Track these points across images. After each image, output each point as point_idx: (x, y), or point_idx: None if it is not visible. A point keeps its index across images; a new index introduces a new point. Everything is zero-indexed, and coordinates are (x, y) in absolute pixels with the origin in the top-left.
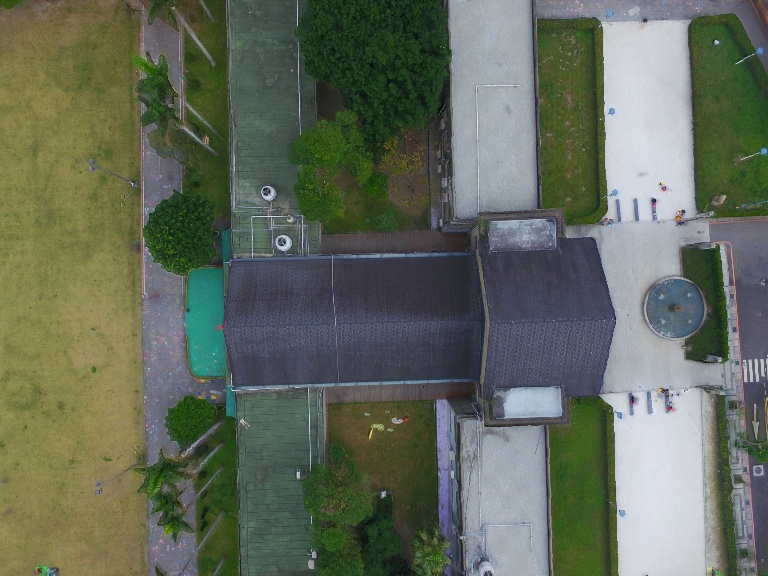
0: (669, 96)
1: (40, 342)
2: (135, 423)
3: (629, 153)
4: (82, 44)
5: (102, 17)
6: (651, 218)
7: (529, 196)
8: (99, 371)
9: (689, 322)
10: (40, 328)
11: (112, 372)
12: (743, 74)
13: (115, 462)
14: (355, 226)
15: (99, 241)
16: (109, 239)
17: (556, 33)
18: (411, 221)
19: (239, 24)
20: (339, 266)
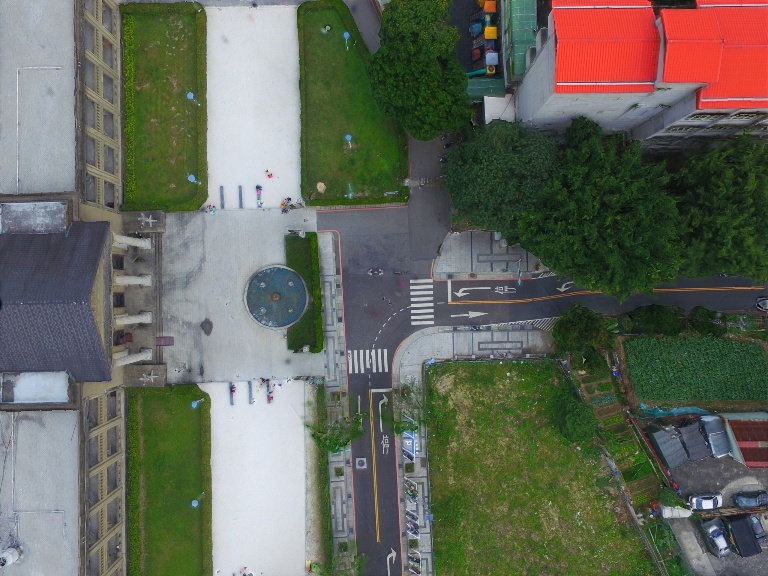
0: (279, 82)
1: None
2: None
3: (236, 140)
4: None
5: None
6: (255, 205)
7: (70, 180)
8: None
9: (290, 311)
10: None
11: None
12: (355, 60)
13: None
14: None
15: None
16: None
17: (163, 18)
18: None
19: None
20: None
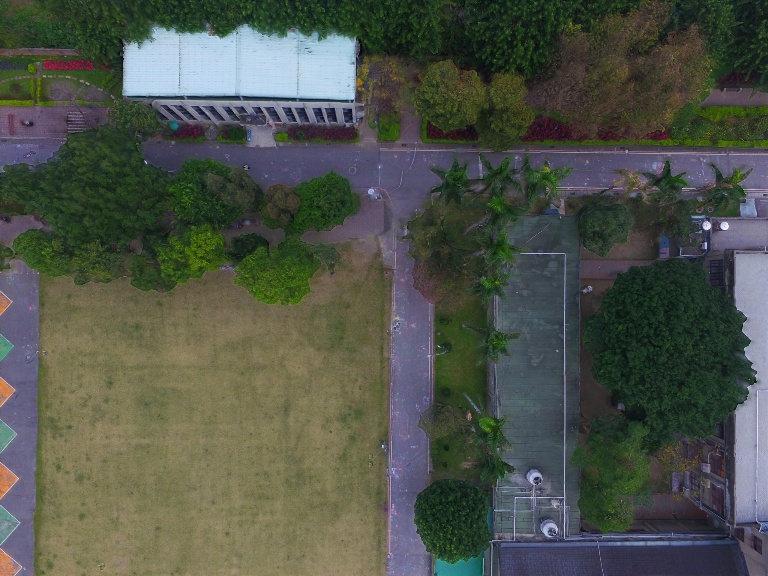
0: None
1: None
2: None
3: None
4: (335, 303)
5: (355, 276)
6: None
7: None
8: None
9: None
10: None
11: None
12: None
13: None
14: None
15: (347, 501)
16: (357, 499)
17: None
18: (652, 484)
19: (506, 303)
20: (606, 555)
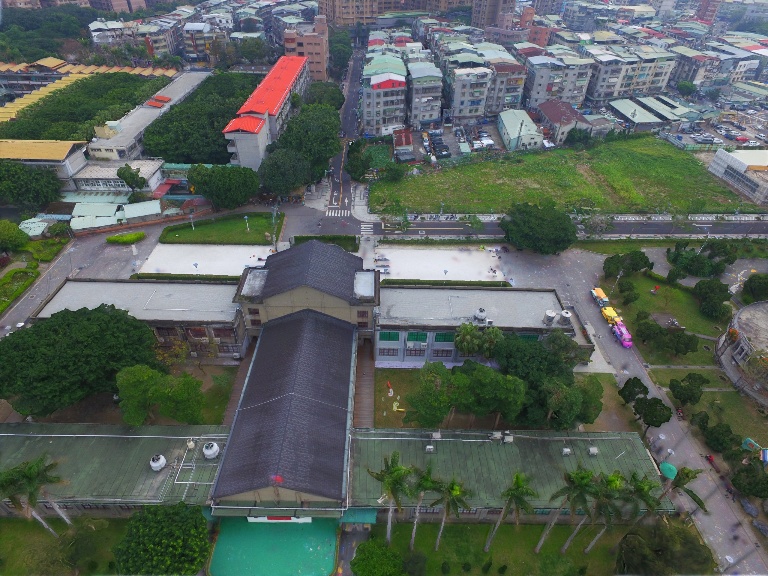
0: (199, 252)
1: None
2: None
3: (226, 268)
4: None
5: None
6: None
7: (232, 289)
8: None
9: None
10: None
11: None
12: (201, 228)
13: None
14: (218, 417)
15: None
16: None
17: None
18: None
19: None
20: (246, 404)
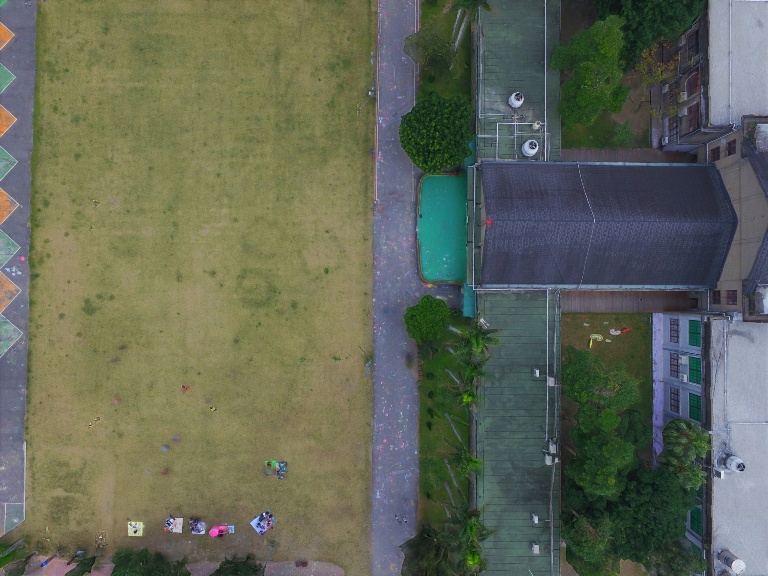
0: None
1: (276, 242)
2: (364, 324)
3: None
4: None
5: None
6: None
7: None
8: (331, 272)
9: None
10: (276, 228)
11: (343, 274)
12: None
13: (344, 361)
14: (579, 142)
15: (335, 147)
16: (345, 145)
17: None
18: (632, 140)
19: None
20: (585, 171)
